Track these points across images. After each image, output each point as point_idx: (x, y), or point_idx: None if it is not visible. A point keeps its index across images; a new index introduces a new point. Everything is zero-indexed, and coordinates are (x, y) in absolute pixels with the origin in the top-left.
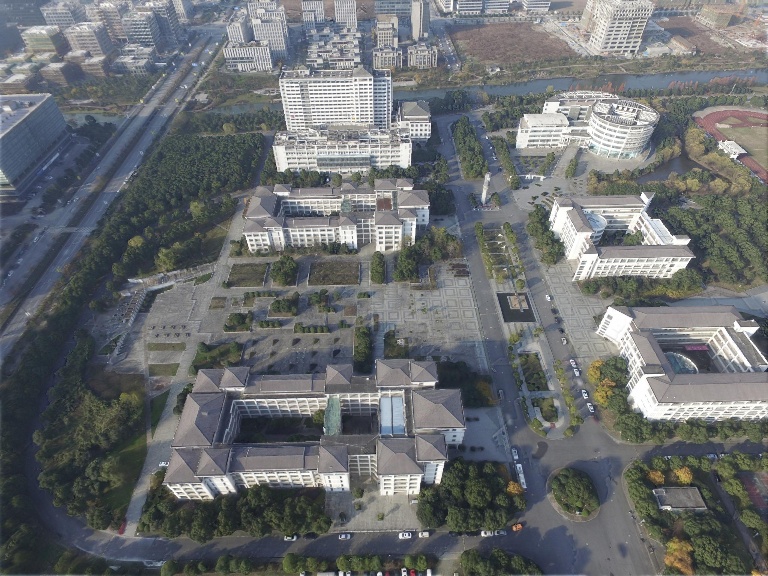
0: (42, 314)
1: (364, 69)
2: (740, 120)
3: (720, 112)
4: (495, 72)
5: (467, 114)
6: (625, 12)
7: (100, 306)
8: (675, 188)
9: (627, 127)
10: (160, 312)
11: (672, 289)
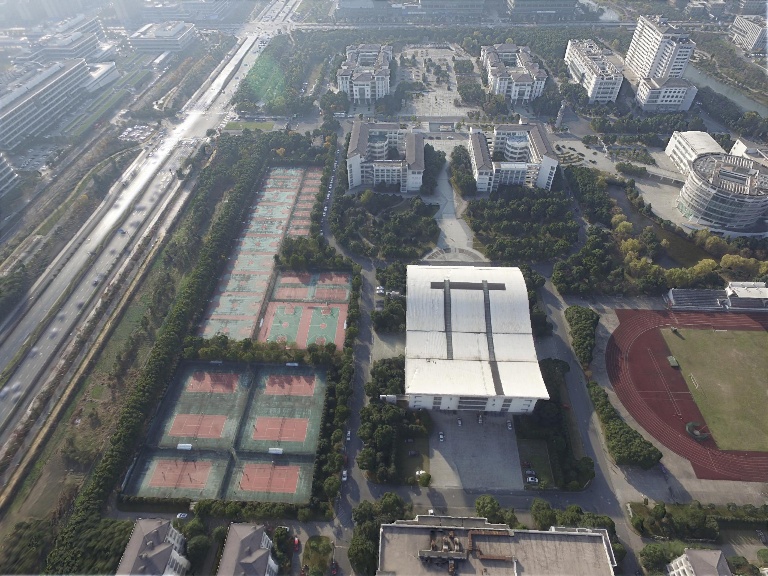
0: (430, 29)
1: (668, 28)
2: None
3: None
4: None
5: (731, 135)
6: None
7: (436, 37)
8: None
9: None
10: (436, 50)
11: None
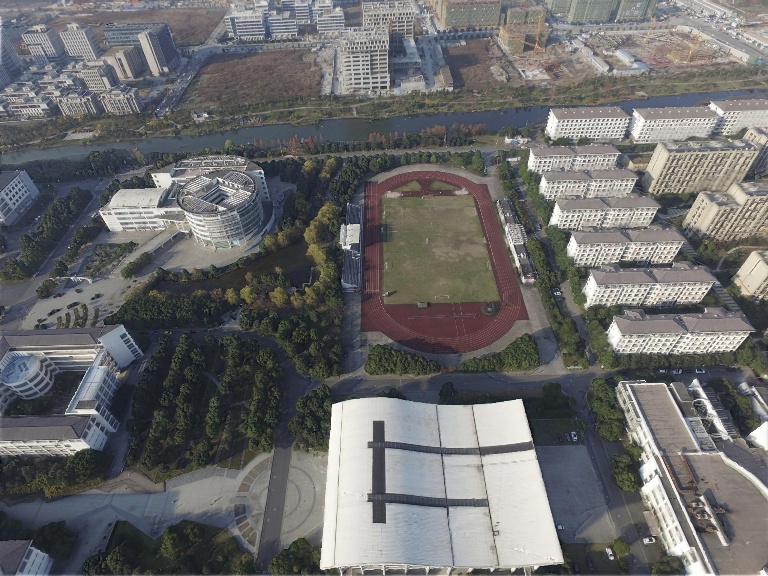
0: None
1: None
2: (420, 186)
3: (407, 174)
4: (201, 118)
5: (108, 179)
6: (356, 45)
7: None
8: (222, 300)
9: (197, 215)
10: None
11: (48, 484)
